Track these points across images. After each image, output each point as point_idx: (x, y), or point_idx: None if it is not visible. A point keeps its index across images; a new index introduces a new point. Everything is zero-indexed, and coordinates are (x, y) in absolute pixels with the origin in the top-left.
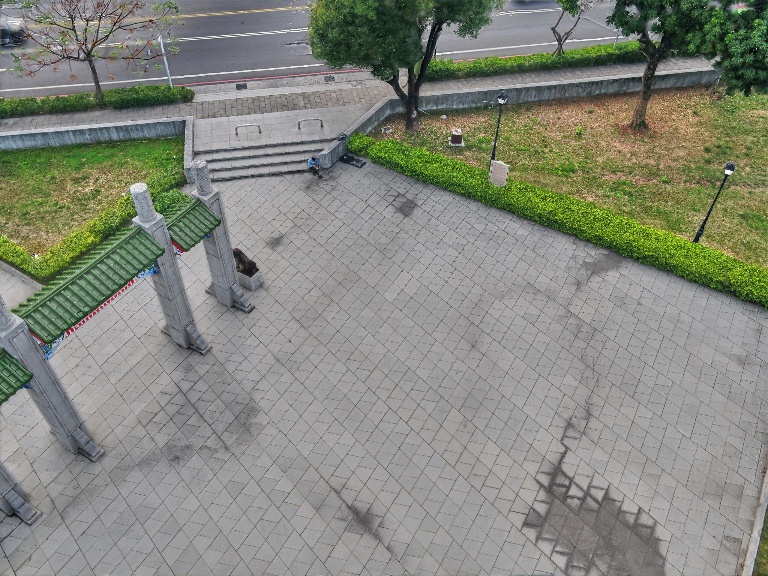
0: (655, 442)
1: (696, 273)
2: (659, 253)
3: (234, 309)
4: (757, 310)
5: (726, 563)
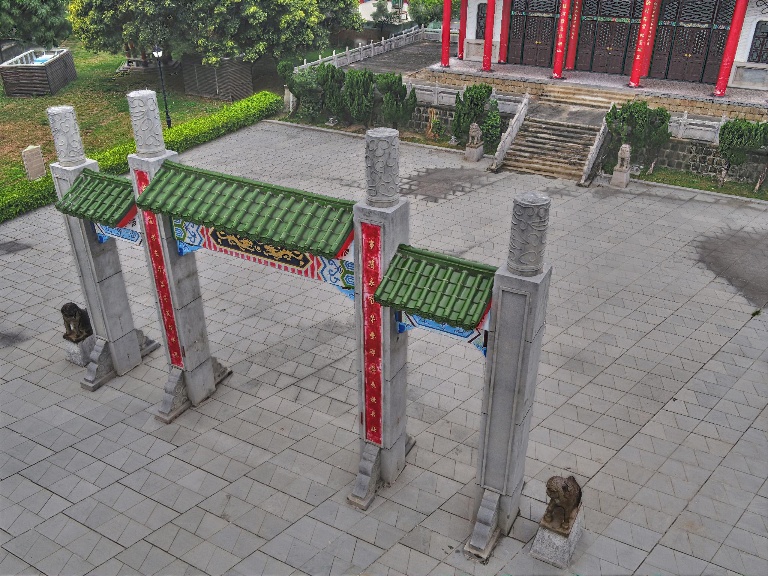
0: (362, 163)
1: (209, 131)
2: (183, 136)
3: (147, 358)
4: (247, 129)
5: (446, 155)
